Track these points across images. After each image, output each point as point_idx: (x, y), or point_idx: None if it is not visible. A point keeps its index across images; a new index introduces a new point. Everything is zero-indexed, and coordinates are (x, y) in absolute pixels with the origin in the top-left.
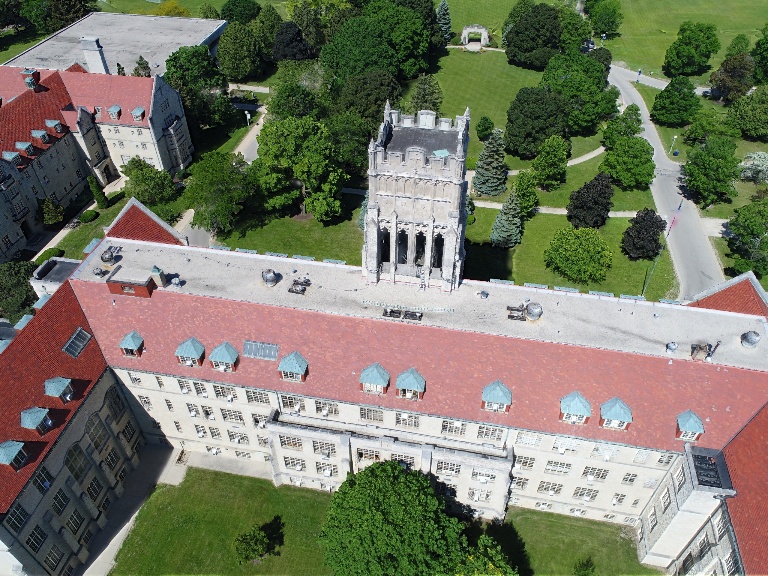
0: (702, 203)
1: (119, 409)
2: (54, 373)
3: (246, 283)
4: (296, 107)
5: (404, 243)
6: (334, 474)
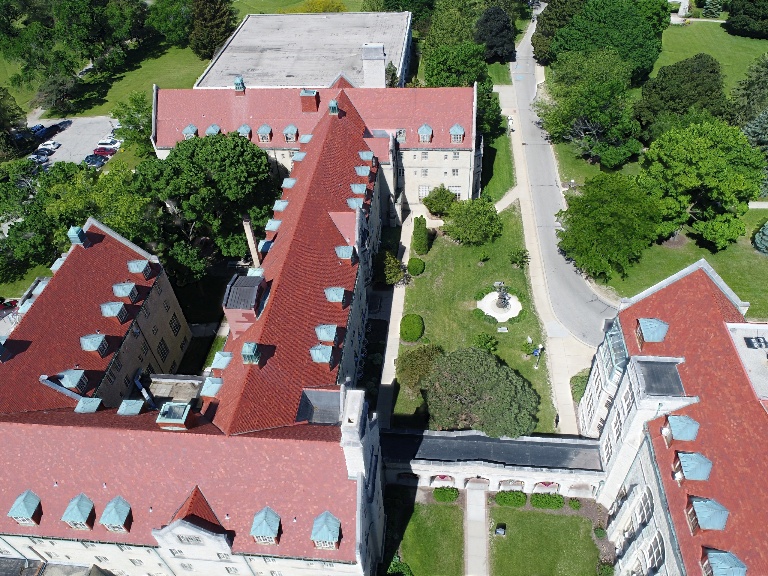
0: None
1: None
2: None
3: None
4: None
5: None
6: None
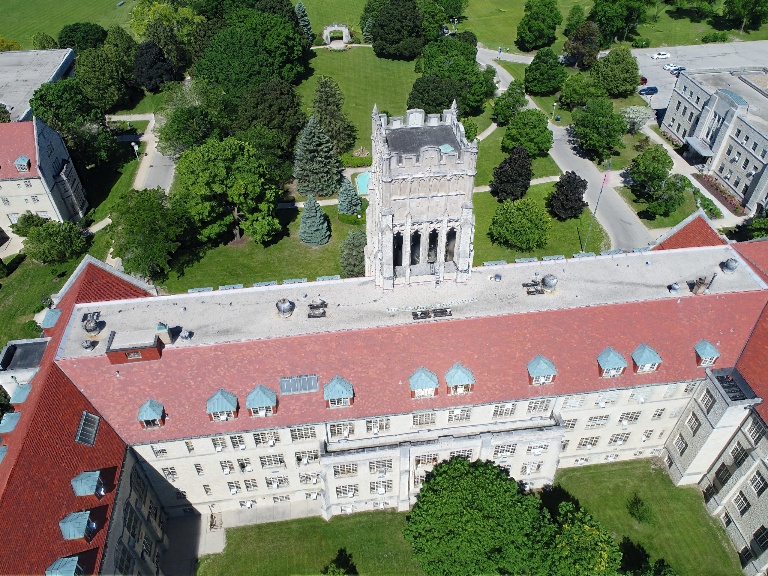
0: (596, 159)
1: (141, 490)
2: (77, 469)
3: (260, 319)
4: (197, 129)
5: (417, 244)
6: (388, 490)
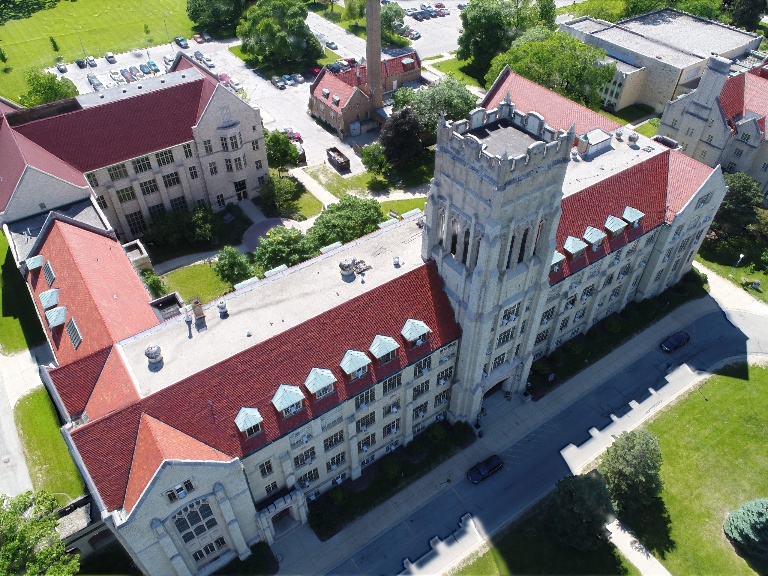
0: None
1: None
2: None
3: None
4: None
5: None
6: None
